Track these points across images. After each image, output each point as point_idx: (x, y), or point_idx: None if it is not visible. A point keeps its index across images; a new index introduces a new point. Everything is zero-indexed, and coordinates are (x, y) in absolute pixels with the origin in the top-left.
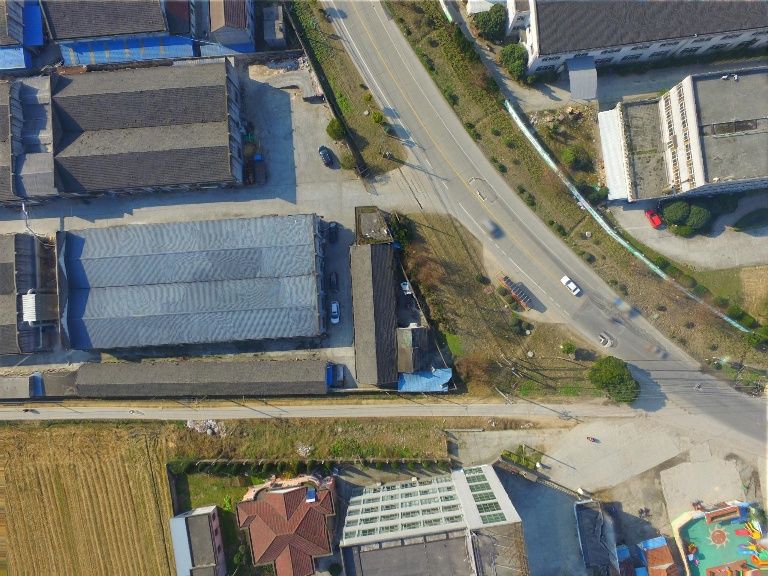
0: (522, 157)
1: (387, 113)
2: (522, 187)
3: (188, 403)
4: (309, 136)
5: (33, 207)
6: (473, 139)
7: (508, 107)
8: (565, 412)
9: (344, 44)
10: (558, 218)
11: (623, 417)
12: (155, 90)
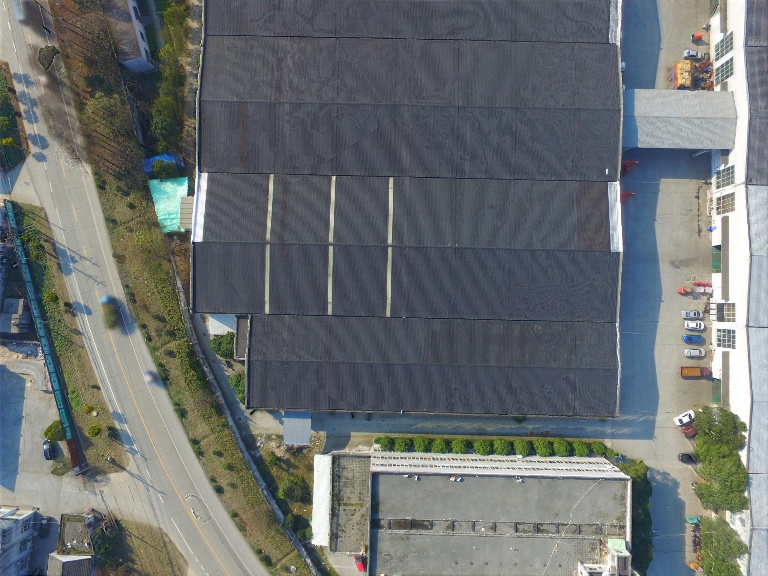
0: (240, 482)
1: (115, 417)
2: (236, 511)
3: None
4: (38, 425)
5: None
6: (196, 455)
7: None
8: None
9: (84, 341)
10: (266, 548)
11: None
12: None
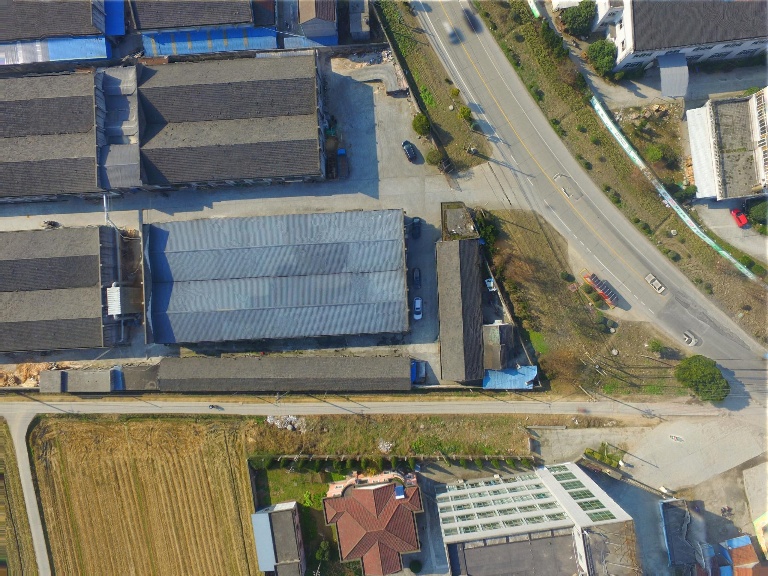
0: (608, 154)
1: (472, 108)
2: (607, 184)
3: (269, 398)
4: (392, 130)
5: (113, 199)
6: (558, 135)
7: (594, 104)
8: (648, 410)
9: (429, 38)
10: (643, 216)
11: (706, 416)
12: (243, 82)
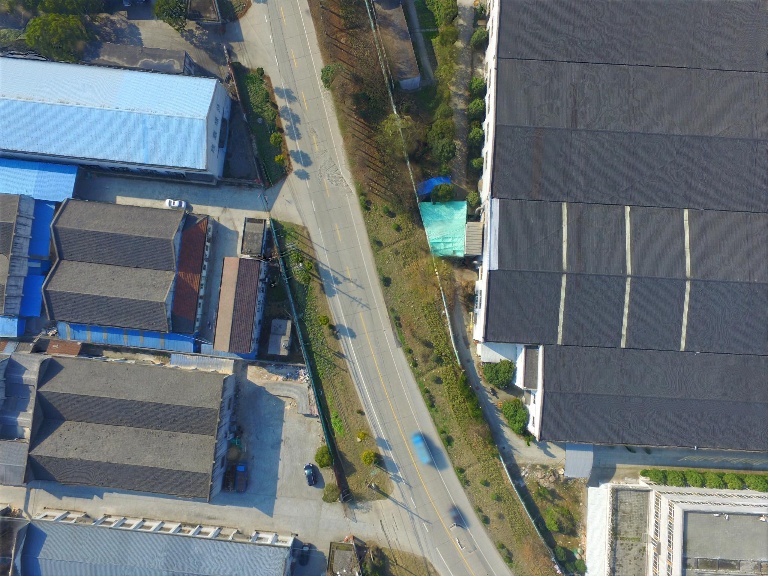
0: (507, 512)
1: (380, 443)
2: (502, 542)
3: None
4: (297, 449)
5: None
6: (461, 484)
7: None
8: None
9: (348, 364)
10: None
11: None
12: (146, 402)
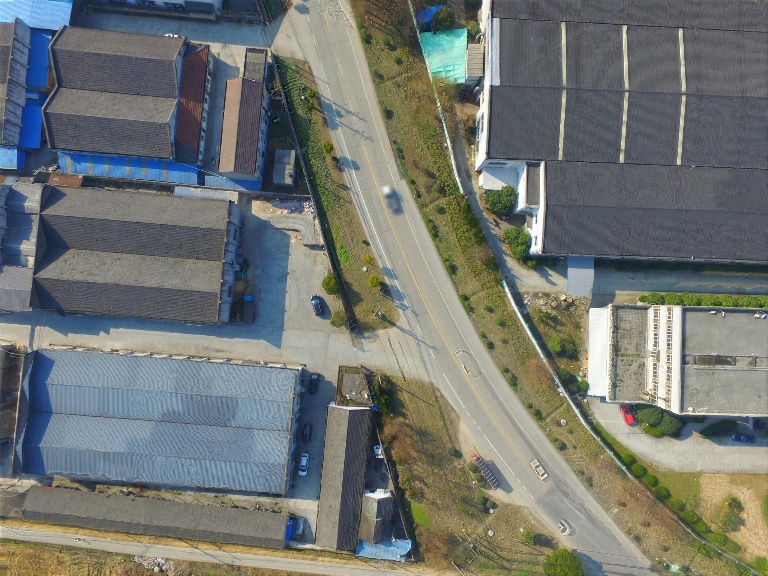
0: (511, 337)
1: (385, 272)
2: (507, 366)
3: (139, 538)
4: (304, 282)
5: (3, 315)
6: (466, 311)
7: (505, 286)
8: None
9: (352, 196)
10: (537, 402)
11: None
12: (151, 223)
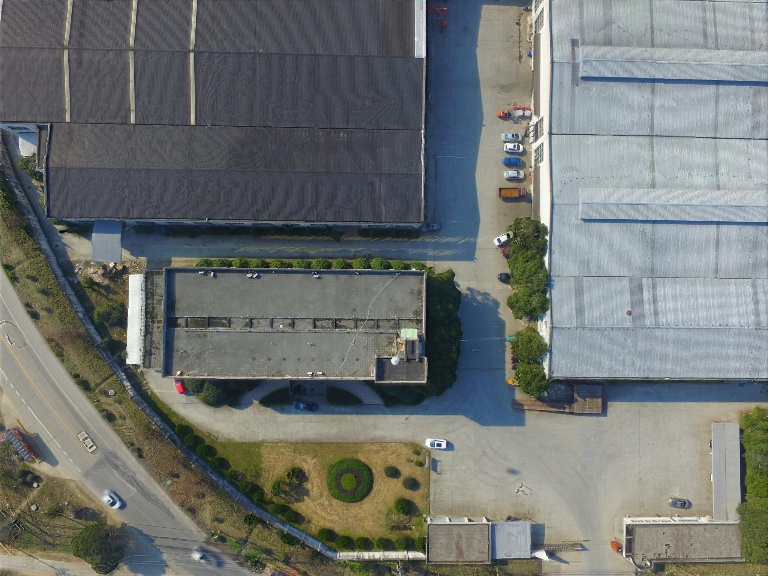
0: (56, 307)
1: None
2: (53, 336)
3: None
4: None
5: None
6: (10, 281)
7: (48, 254)
8: (63, 569)
9: None
10: (84, 373)
11: None
12: None
